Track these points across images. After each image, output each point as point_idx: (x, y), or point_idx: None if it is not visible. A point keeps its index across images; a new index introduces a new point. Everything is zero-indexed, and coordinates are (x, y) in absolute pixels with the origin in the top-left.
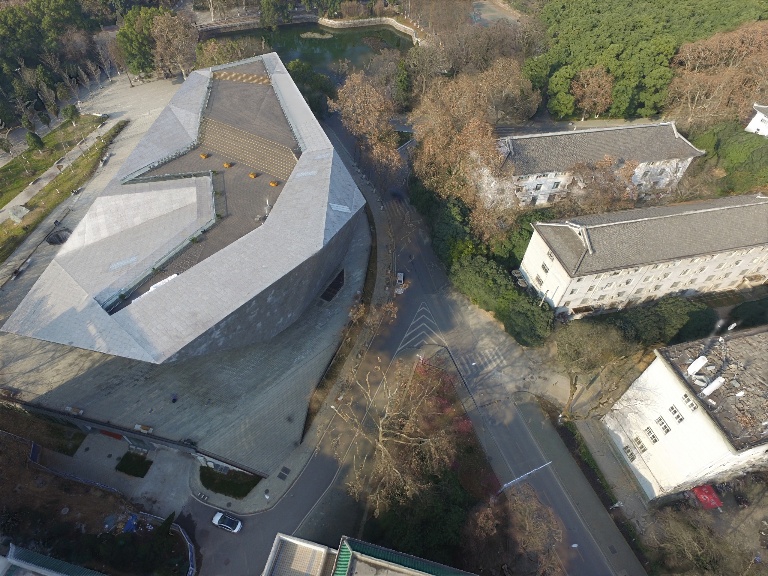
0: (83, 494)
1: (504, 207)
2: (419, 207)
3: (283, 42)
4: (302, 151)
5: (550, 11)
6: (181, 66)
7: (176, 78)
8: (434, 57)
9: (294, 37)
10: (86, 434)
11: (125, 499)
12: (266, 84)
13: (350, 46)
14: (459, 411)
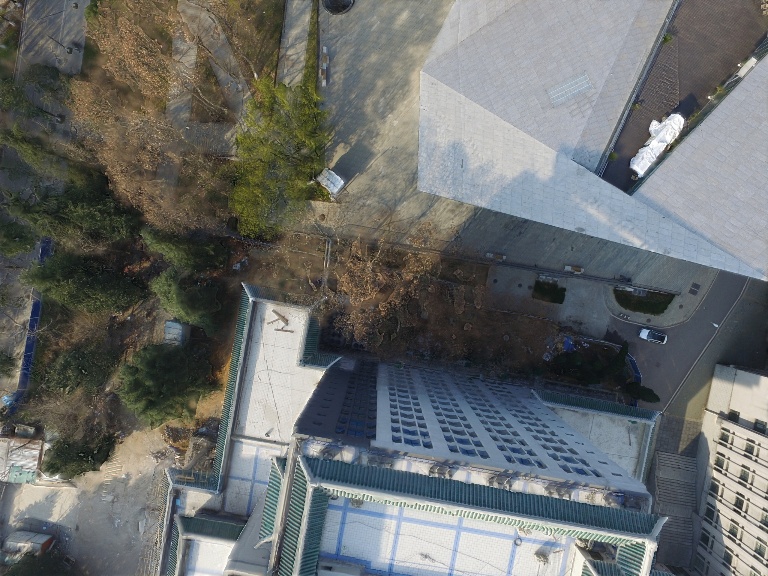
0: (513, 322)
1: None
2: None
3: None
4: None
5: None
6: None
7: None
8: None
9: None
10: (488, 267)
11: (559, 326)
12: None
13: None
14: None
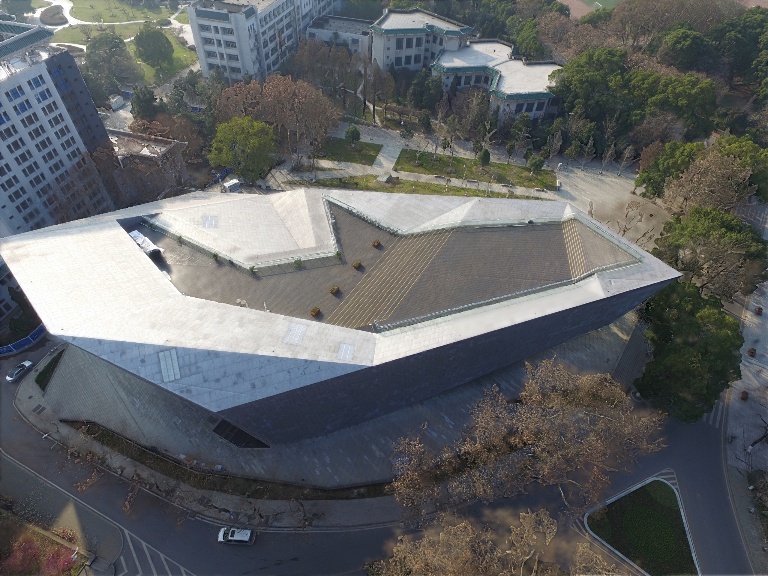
0: None
1: None
2: None
3: None
4: (381, 333)
5: None
6: None
7: None
8: None
9: None
10: None
11: None
12: (572, 277)
13: None
14: None
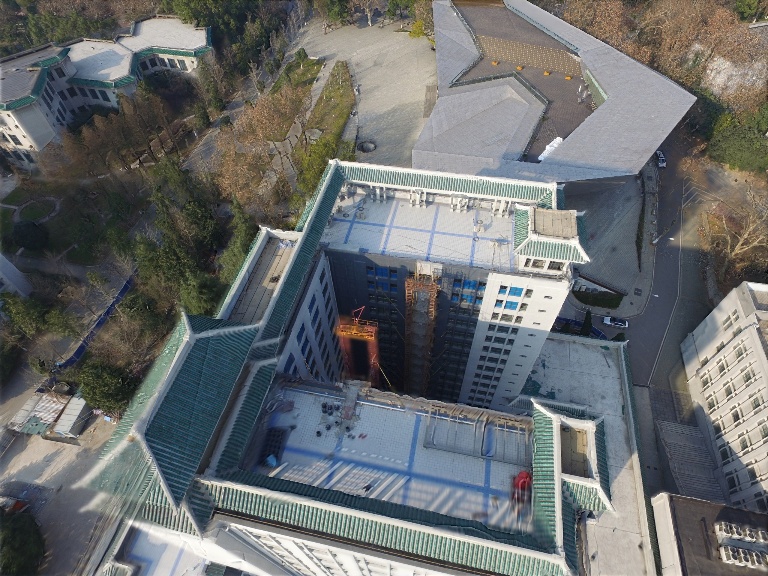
0: None
1: (765, 80)
2: None
3: None
4: (576, 52)
5: None
6: (368, 10)
7: (358, 23)
8: None
9: None
10: None
11: None
12: (501, 6)
13: None
14: (759, 241)
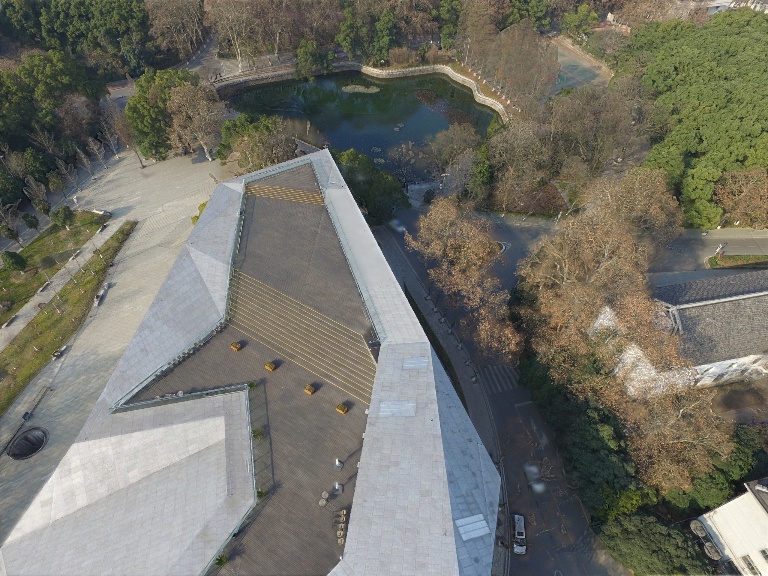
0: None
1: None
2: (537, 398)
3: (320, 92)
4: (380, 341)
5: (656, 72)
6: (203, 143)
7: (196, 154)
8: (530, 149)
9: (332, 85)
10: None
11: None
12: (318, 204)
13: (395, 94)
14: None
